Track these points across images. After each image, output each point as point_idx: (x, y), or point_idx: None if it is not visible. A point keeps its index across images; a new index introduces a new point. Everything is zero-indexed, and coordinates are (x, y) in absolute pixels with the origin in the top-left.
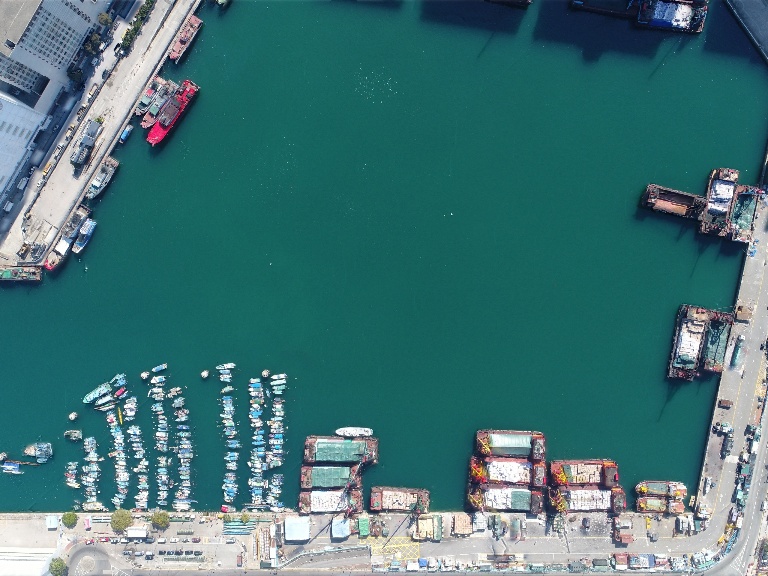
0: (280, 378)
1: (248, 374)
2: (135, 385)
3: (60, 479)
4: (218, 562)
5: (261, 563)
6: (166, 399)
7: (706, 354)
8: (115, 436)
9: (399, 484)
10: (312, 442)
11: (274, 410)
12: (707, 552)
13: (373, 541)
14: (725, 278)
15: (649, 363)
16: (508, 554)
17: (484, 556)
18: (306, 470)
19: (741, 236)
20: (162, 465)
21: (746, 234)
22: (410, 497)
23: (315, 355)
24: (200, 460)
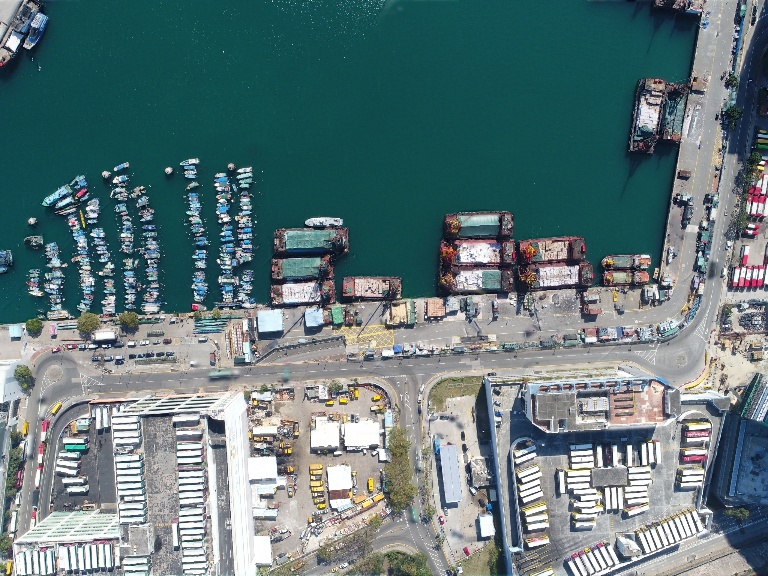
0: (246, 172)
1: (213, 170)
2: (96, 187)
3: (22, 288)
4: (191, 362)
5: (235, 359)
6: (130, 200)
7: (664, 125)
8: (78, 240)
9: (371, 273)
10: (282, 231)
11: (242, 205)
12: (672, 320)
13: (347, 331)
14: (680, 52)
15: (611, 140)
16: (481, 335)
17: (458, 339)
18: (277, 260)
19: (694, 5)
20: (128, 268)
21: (698, 3)
22: (382, 284)
23: (281, 146)
24: (168, 260)
